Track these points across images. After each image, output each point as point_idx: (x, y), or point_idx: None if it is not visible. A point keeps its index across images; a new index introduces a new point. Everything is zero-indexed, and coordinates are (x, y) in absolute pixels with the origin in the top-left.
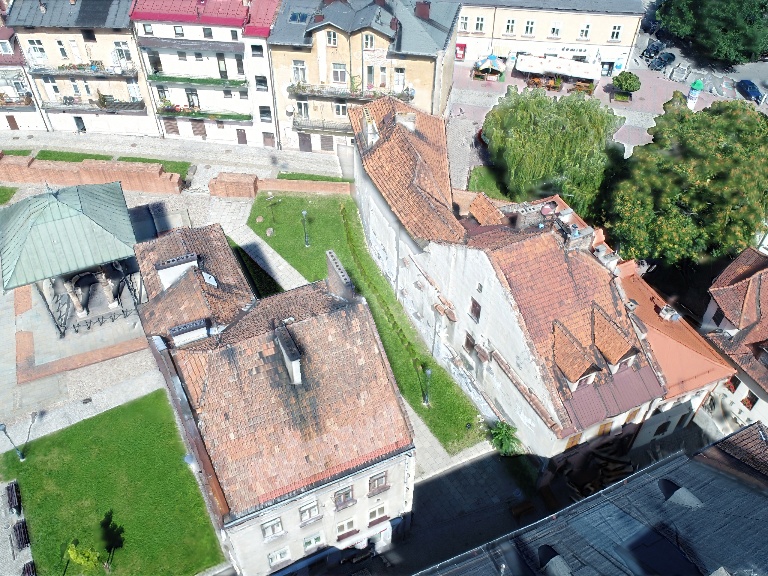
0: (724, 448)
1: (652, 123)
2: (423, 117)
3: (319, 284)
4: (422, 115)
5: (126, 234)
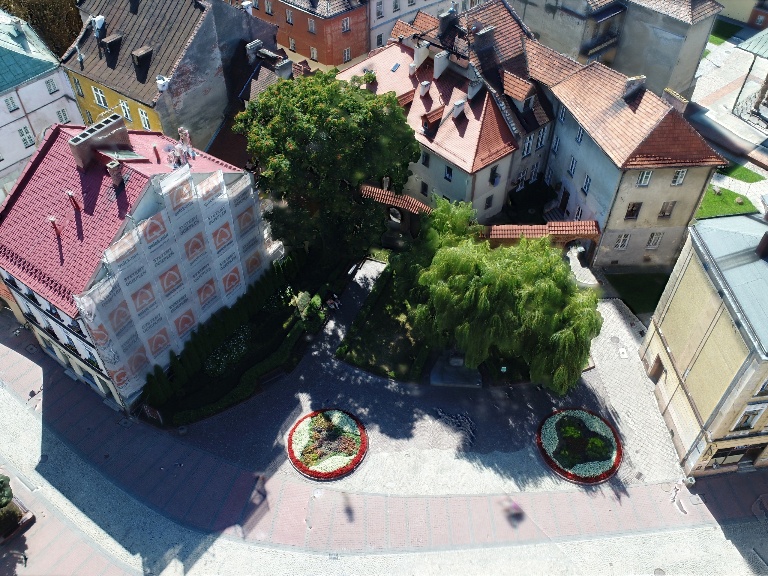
0: (349, 4)
1: (348, 574)
2: (636, 138)
3: (593, 4)
4: (639, 138)
5: (760, 48)
